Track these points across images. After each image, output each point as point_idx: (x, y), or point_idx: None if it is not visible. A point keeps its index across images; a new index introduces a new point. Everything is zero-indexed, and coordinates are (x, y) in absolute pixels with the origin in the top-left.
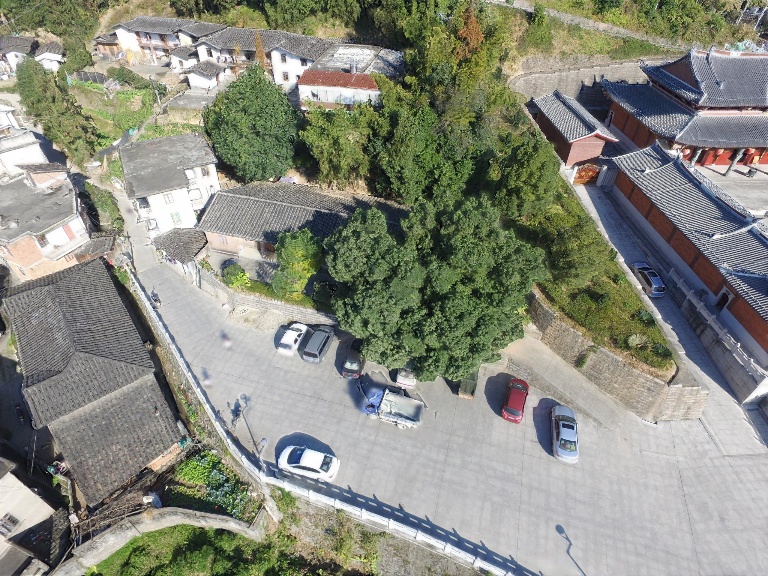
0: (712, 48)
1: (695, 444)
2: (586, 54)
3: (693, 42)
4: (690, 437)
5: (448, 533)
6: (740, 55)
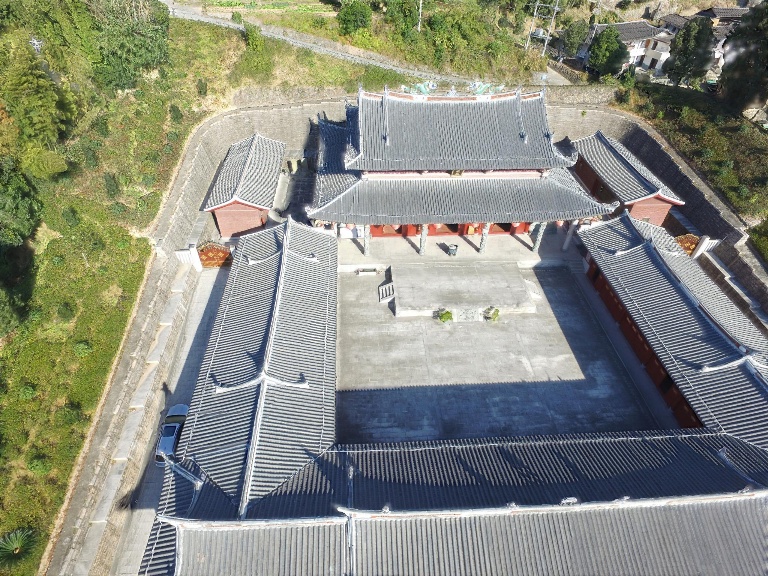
0: (385, 90)
1: None
2: (314, 86)
3: (462, 70)
4: None
5: None
6: (428, 99)
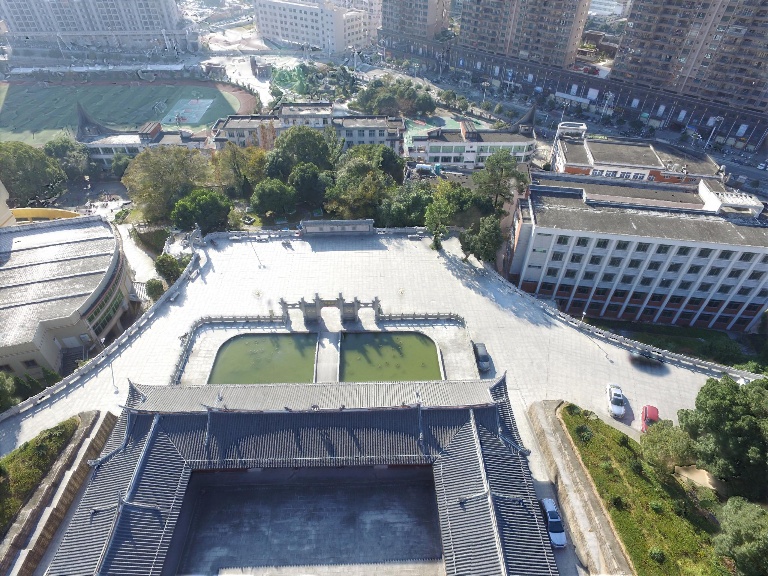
0: None
1: (534, 395)
2: None
3: None
4: (536, 399)
5: (665, 362)
6: None
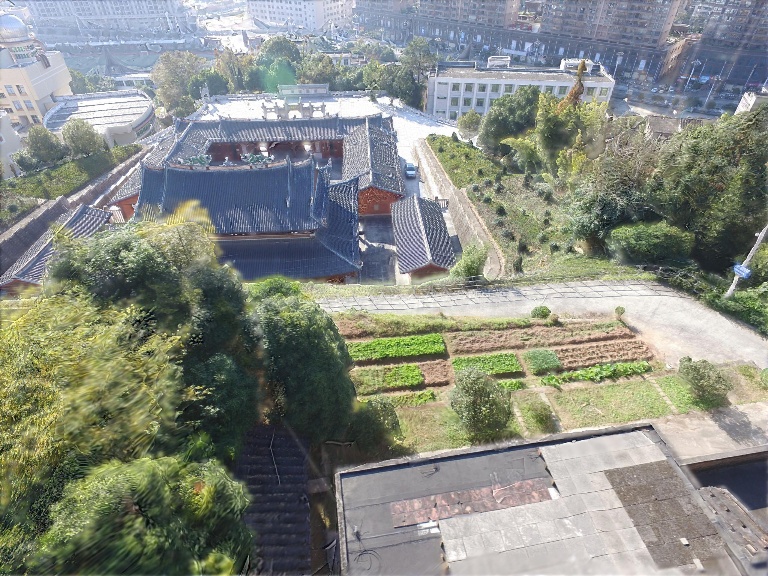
0: None
1: None
2: None
3: None
4: None
5: None
6: (252, 167)
